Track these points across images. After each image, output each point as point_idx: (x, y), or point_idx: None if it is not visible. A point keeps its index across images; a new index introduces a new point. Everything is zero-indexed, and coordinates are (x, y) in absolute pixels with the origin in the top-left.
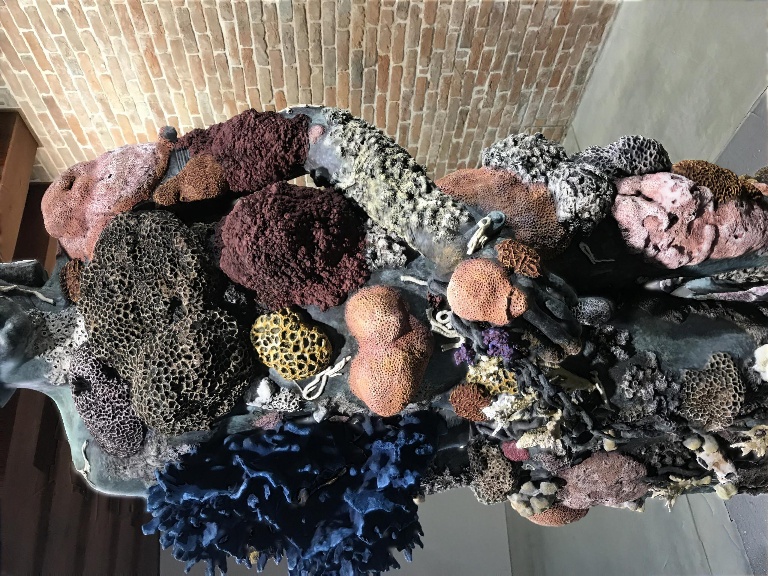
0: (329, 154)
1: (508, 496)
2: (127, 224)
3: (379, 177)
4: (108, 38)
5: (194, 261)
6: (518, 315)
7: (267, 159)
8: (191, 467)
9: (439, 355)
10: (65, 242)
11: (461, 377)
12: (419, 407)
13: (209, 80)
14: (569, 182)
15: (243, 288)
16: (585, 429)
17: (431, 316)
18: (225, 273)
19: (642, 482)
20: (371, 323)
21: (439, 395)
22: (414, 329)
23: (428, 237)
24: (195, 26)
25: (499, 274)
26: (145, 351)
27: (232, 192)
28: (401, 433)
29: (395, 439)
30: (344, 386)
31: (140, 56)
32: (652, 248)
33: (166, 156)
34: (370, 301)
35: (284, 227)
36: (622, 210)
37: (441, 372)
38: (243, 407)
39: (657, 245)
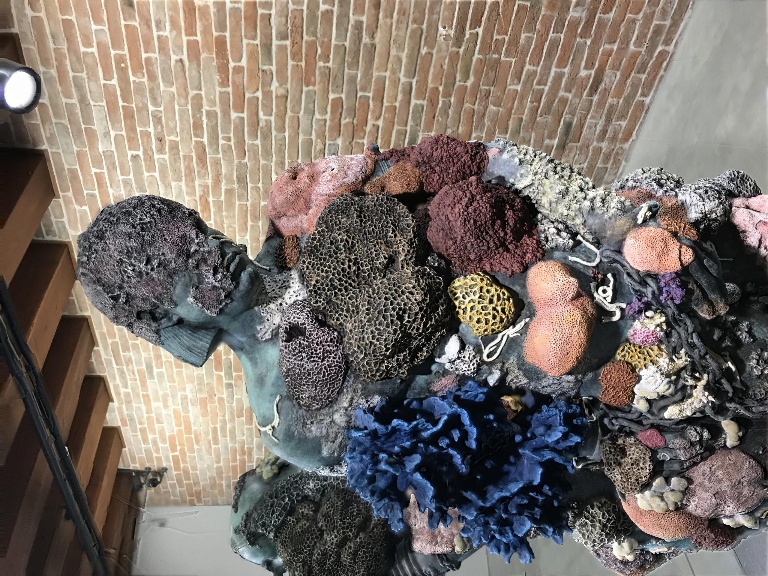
0: (507, 165)
1: (640, 494)
2: (352, 199)
3: (553, 177)
4: (170, 183)
5: (413, 224)
6: (687, 264)
7: (458, 166)
8: (384, 414)
9: (598, 327)
10: (284, 221)
11: (611, 355)
12: (574, 382)
13: (251, 227)
14: (696, 193)
15: (442, 256)
16: (726, 397)
17: (595, 289)
18: (429, 242)
19: (760, 486)
20: (553, 284)
21: (591, 373)
22: (584, 296)
23: (599, 217)
24: (250, 178)
25: (669, 233)
26: (367, 293)
27: (424, 192)
28: (562, 402)
29: (557, 407)
30: (518, 349)
31: (195, 200)
32: (764, 249)
33: (373, 162)
34: (550, 268)
35: (488, 201)
36: (739, 216)
37: (598, 345)
38: (429, 365)
39: (767, 247)
